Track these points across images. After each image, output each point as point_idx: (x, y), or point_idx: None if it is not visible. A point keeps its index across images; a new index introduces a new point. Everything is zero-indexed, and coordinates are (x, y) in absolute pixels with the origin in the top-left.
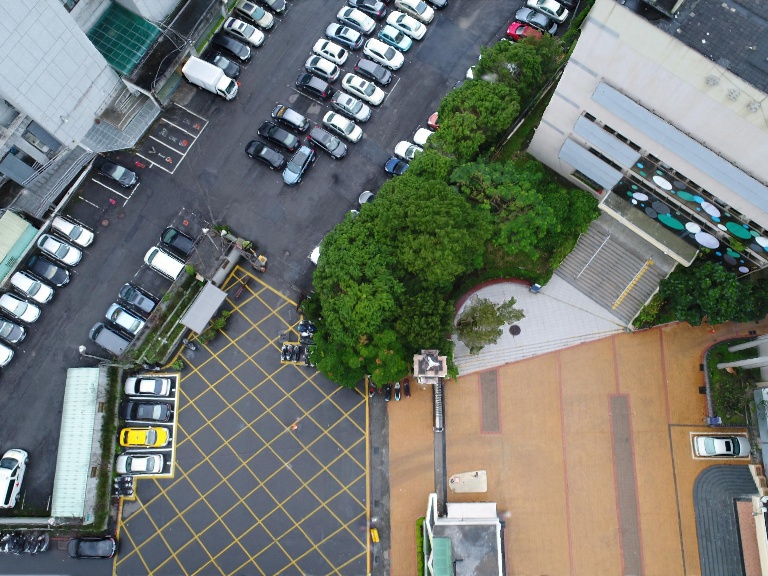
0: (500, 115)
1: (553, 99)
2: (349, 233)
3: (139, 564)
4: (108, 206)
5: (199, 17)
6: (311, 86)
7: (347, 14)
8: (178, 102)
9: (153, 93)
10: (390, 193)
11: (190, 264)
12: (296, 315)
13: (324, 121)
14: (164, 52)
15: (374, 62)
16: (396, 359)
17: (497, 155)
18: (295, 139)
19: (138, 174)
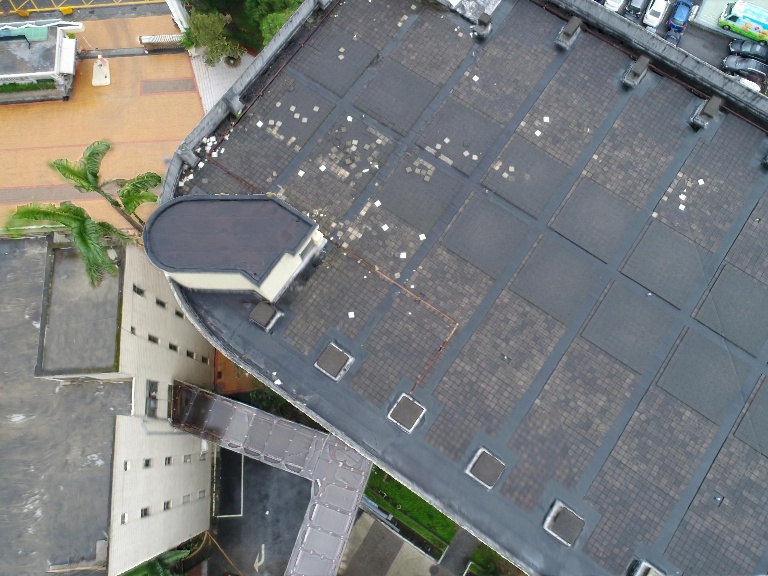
0: None
1: None
2: None
3: None
4: None
5: None
6: None
7: None
8: None
9: None
10: None
11: None
12: None
13: None
14: None
15: None
16: None
17: None
18: None
19: None
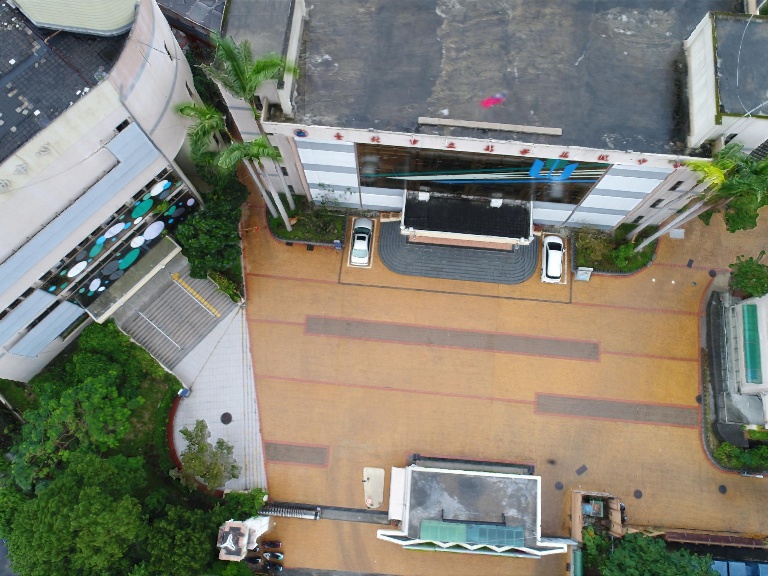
0: None
1: None
2: None
3: None
4: None
5: None
6: None
7: None
8: None
9: None
10: None
11: None
12: None
13: None
14: None
15: None
16: None
17: None
18: None
19: None
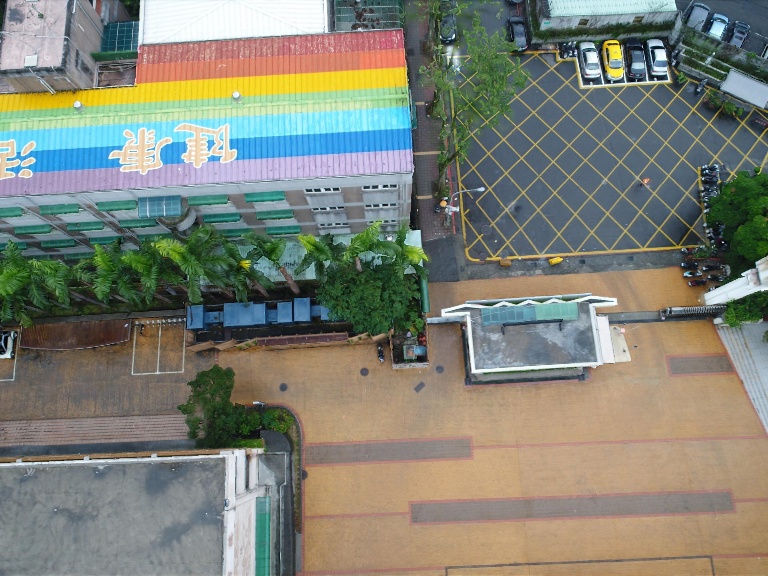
0: None
1: None
2: None
3: None
4: None
5: None
6: None
7: None
8: None
9: None
10: None
11: None
12: None
13: None
14: None
15: None
16: None
17: None
18: None
19: None
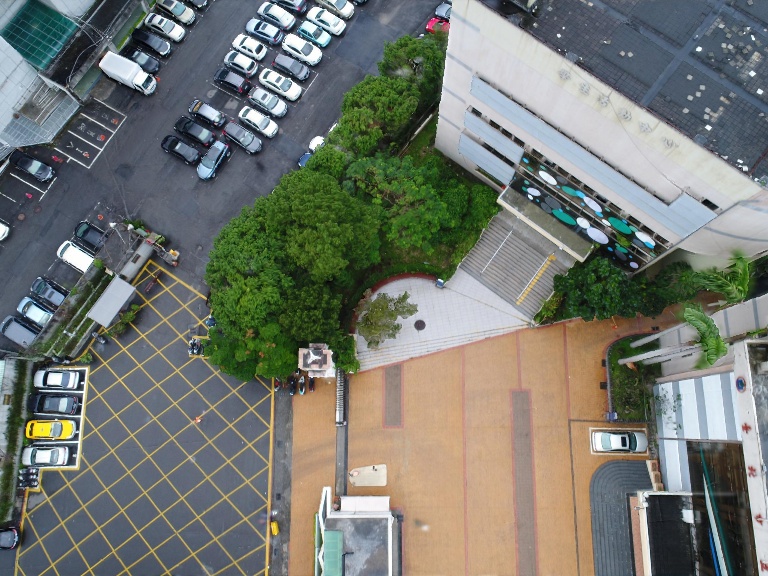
0: (396, 110)
1: (443, 94)
2: (240, 227)
3: (41, 555)
4: (25, 200)
5: (117, 12)
6: (227, 81)
7: (267, 10)
8: (97, 97)
9: (68, 88)
10: (279, 187)
11: (98, 258)
12: (206, 309)
13: (239, 116)
14: (81, 47)
15: (293, 58)
16: (282, 352)
17: (405, 150)
18: (210, 134)
19: (55, 169)
